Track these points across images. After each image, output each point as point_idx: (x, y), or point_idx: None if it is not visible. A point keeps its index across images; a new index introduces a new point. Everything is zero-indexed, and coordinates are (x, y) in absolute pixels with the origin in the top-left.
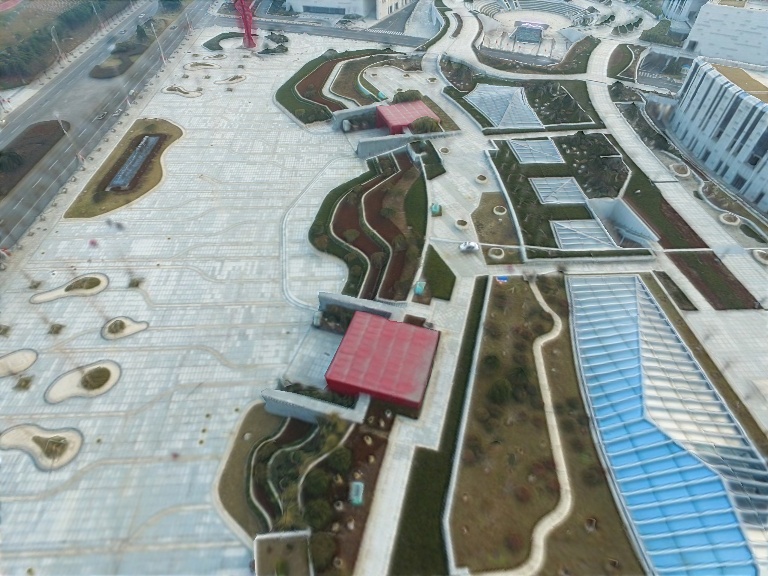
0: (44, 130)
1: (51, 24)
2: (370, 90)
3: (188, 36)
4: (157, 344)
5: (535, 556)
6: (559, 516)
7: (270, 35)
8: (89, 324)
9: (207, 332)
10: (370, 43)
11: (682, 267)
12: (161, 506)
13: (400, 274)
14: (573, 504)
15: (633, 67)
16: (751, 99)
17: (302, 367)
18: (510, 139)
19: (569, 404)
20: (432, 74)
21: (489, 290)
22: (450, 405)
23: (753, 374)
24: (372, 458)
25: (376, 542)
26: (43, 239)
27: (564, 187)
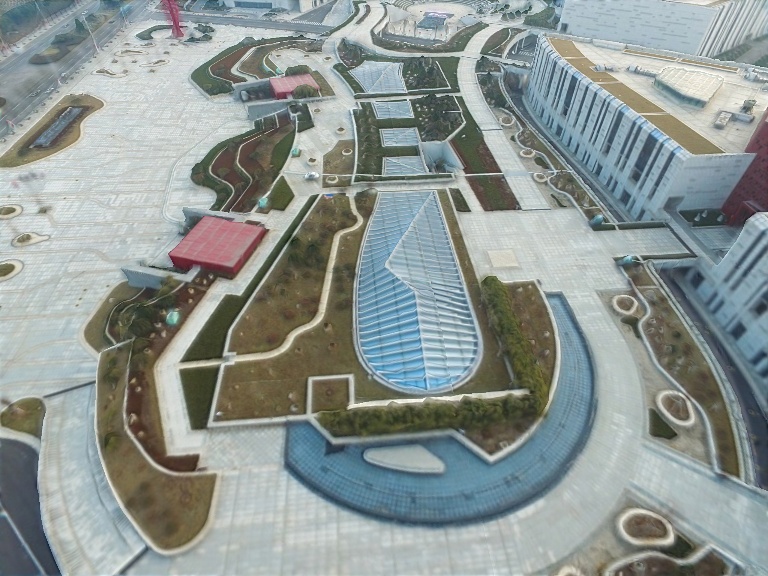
0: None
1: None
2: (271, 68)
3: (124, 28)
4: (55, 249)
5: (285, 345)
6: (311, 326)
7: (198, 26)
8: (3, 237)
9: (95, 240)
10: (288, 32)
11: (474, 185)
12: (40, 342)
13: (252, 196)
14: (323, 319)
15: (504, 45)
16: (561, 62)
17: (164, 259)
18: (374, 101)
19: (345, 267)
20: (330, 54)
21: (316, 203)
22: (259, 271)
23: (491, 248)
24: (191, 300)
25: (180, 344)
26: None
27: (406, 135)
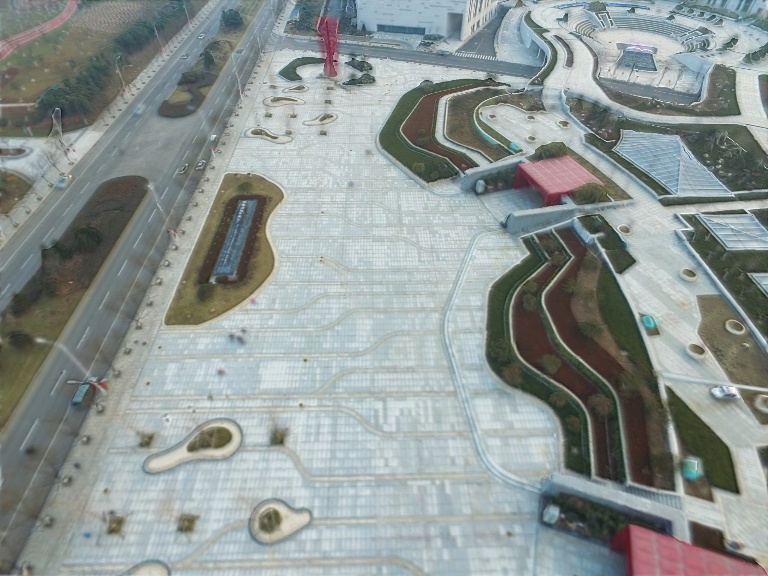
0: (120, 190)
1: (108, 49)
2: (496, 138)
3: (259, 62)
4: (331, 553)
5: None
6: None
7: (351, 61)
8: (230, 512)
9: (396, 530)
10: (464, 71)
11: None
12: None
13: (646, 439)
14: None
15: None
16: None
17: None
18: (700, 213)
19: None
20: (559, 115)
21: None
22: None
23: None
24: None
25: None
26: (144, 359)
27: None
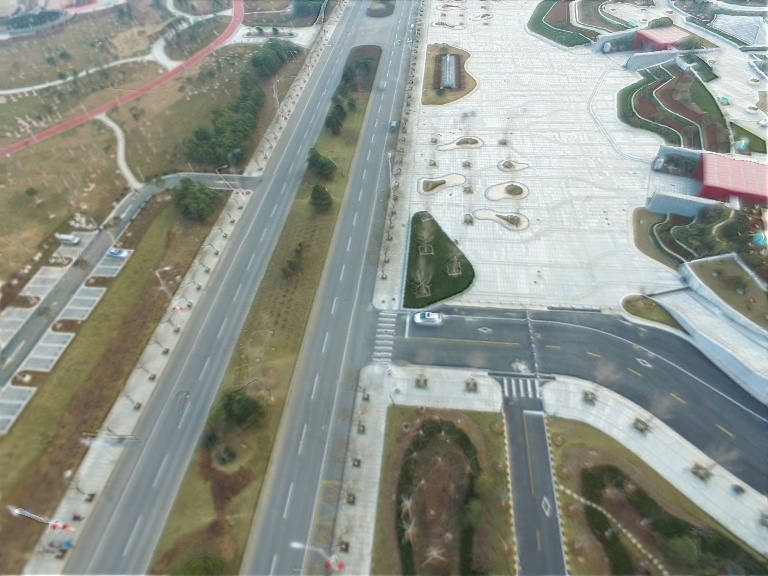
0: (366, 51)
1: None
2: (617, 21)
3: None
4: (542, 175)
5: None
6: None
7: None
8: (487, 163)
9: (574, 171)
10: None
11: None
12: (602, 251)
13: (716, 138)
14: None
15: None
16: None
17: None
18: None
19: None
20: (666, 8)
21: None
22: None
23: None
24: (757, 226)
25: None
26: (418, 116)
27: None
